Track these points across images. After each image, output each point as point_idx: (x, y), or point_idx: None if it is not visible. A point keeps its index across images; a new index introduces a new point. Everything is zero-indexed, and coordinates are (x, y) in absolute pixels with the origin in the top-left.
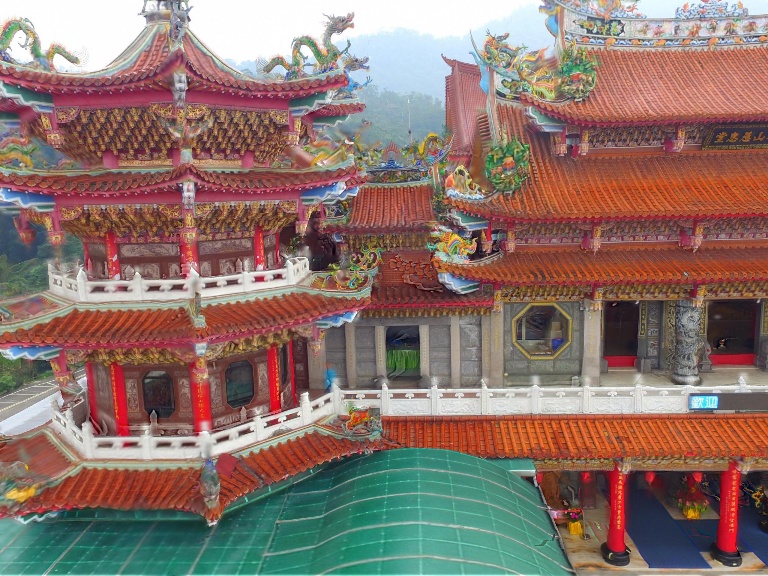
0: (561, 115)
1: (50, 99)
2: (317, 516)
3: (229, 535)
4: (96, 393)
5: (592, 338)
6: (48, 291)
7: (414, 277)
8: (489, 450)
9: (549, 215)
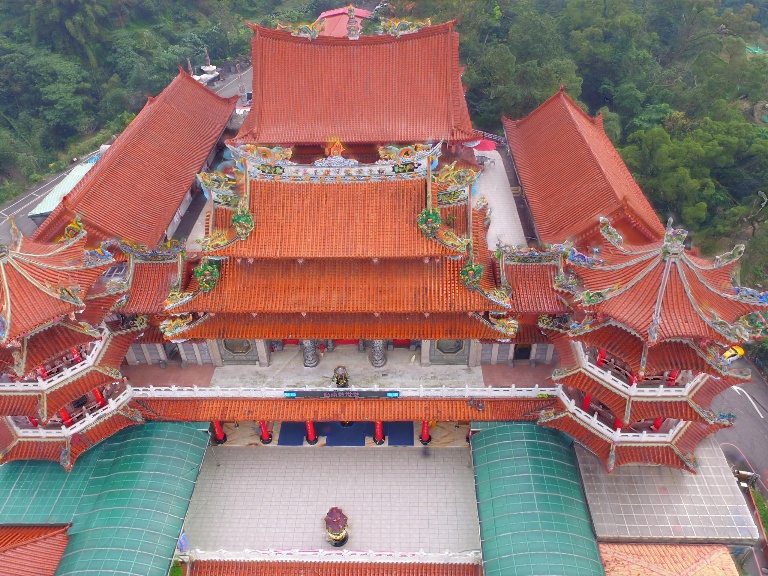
0: None
1: None
2: (112, 459)
3: (79, 468)
4: None
5: (261, 349)
6: None
7: None
8: (193, 418)
9: (222, 311)
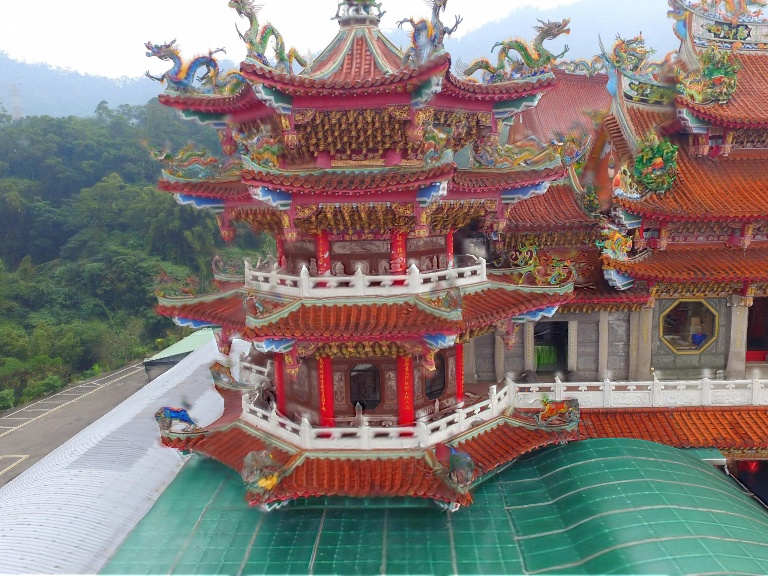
0: (712, 117)
1: (290, 101)
2: (546, 502)
3: (468, 520)
4: (287, 387)
5: (739, 333)
6: (245, 287)
7: None
8: (674, 440)
9: (709, 214)
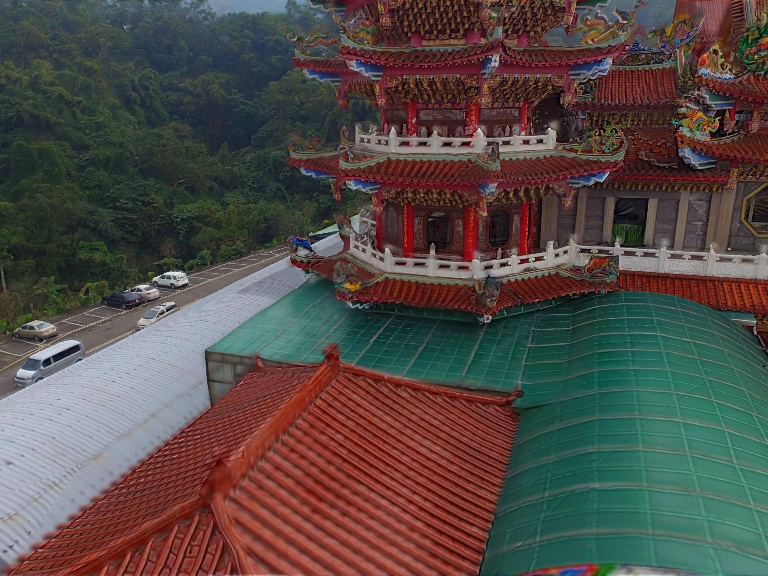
0: None
1: None
2: (566, 328)
3: (498, 332)
4: (384, 230)
5: None
6: (355, 147)
7: (650, 154)
8: (712, 302)
9: None
